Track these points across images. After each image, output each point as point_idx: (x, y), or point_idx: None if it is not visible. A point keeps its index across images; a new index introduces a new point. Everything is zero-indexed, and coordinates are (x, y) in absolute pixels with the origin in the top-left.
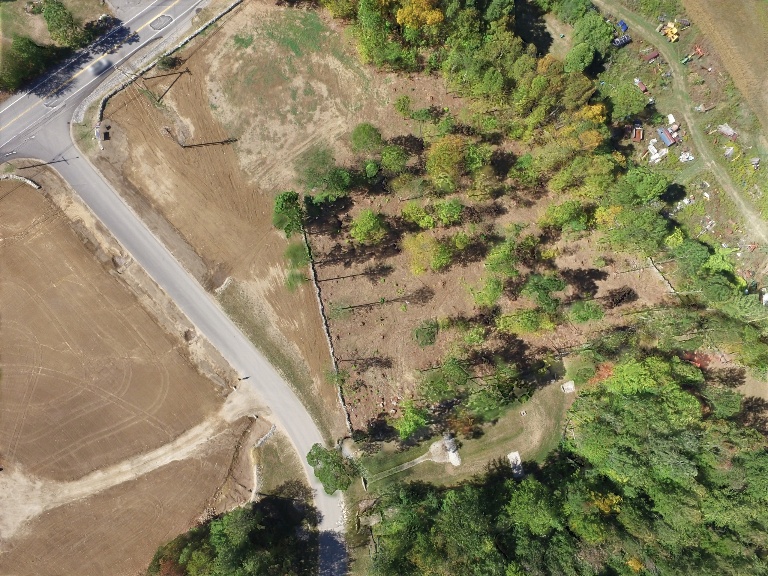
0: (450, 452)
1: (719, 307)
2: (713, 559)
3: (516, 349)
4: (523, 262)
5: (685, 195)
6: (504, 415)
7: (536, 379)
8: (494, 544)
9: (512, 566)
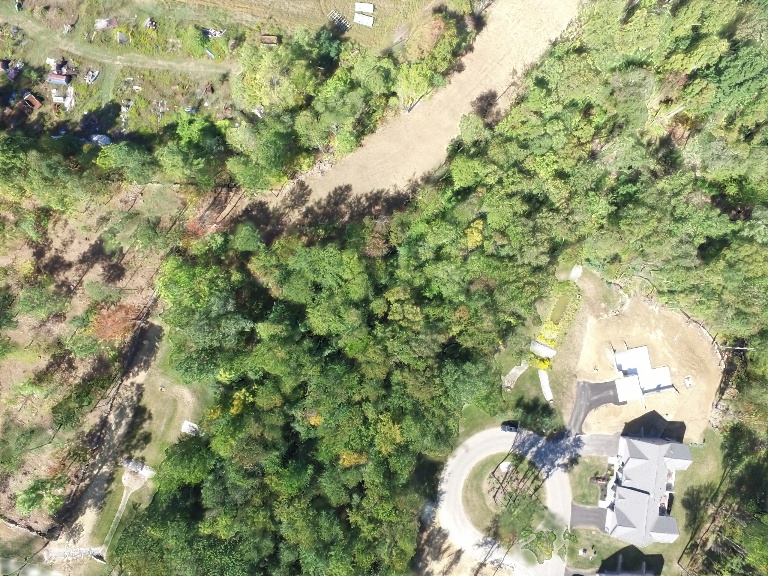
0: (140, 472)
1: (179, 175)
2: (356, 361)
3: (106, 351)
4: (41, 286)
5: (119, 105)
6: (151, 405)
7: (144, 356)
8: (185, 520)
9: (207, 524)
